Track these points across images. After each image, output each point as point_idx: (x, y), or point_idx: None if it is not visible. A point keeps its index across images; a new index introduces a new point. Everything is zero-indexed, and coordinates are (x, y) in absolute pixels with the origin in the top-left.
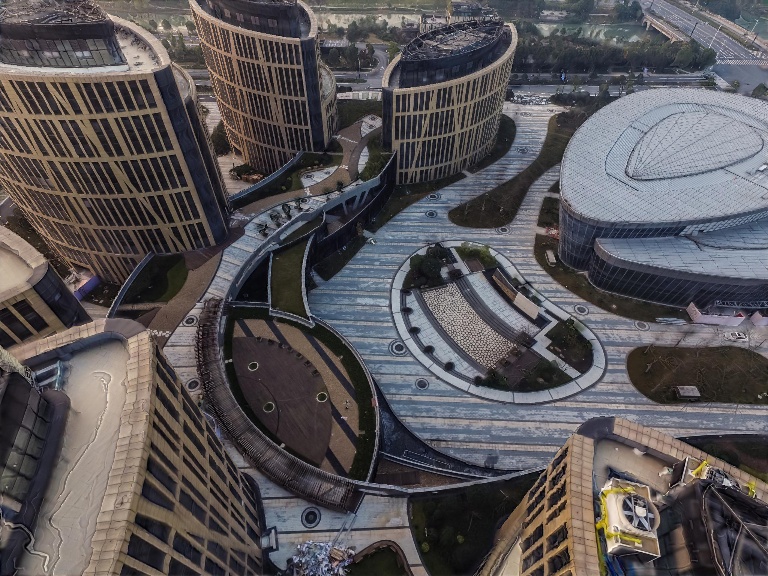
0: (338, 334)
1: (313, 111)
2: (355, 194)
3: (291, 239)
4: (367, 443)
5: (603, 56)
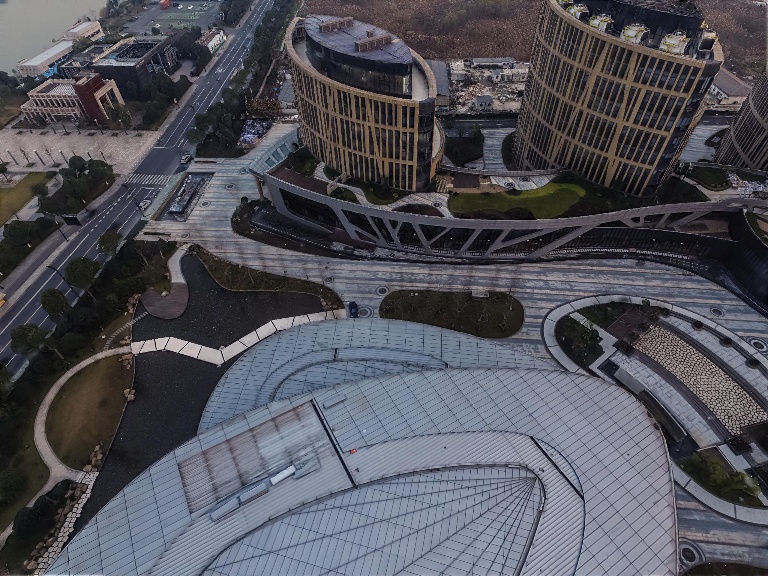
0: None
1: None
2: None
3: None
4: (756, 229)
5: None
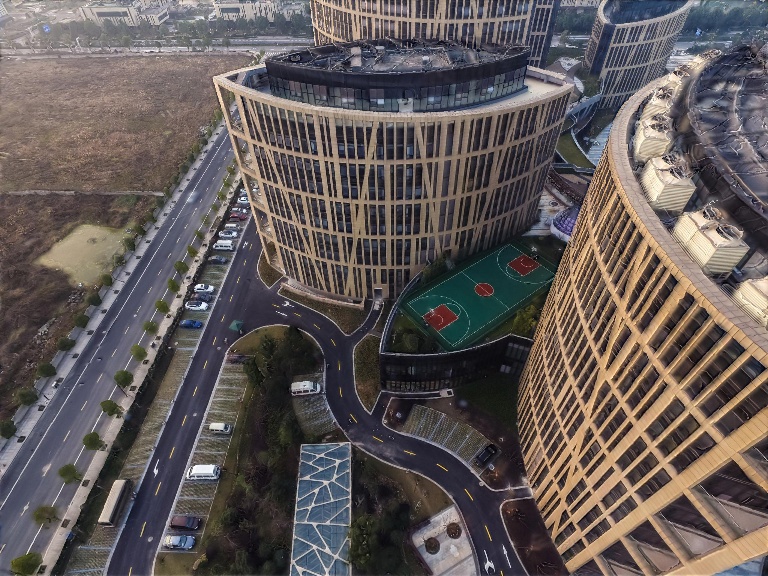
0: None
1: (546, 45)
2: (586, 106)
3: None
4: None
5: (726, 17)
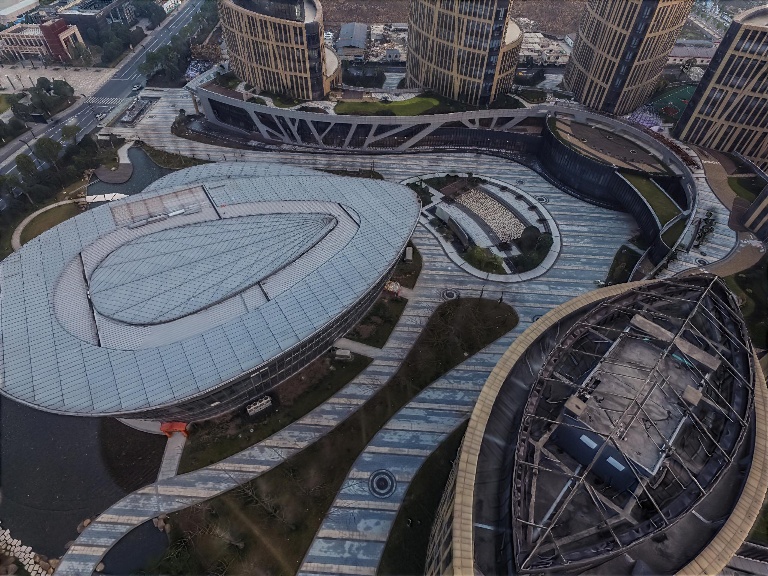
0: (591, 162)
1: None
2: None
3: (679, 226)
4: (552, 126)
5: None
